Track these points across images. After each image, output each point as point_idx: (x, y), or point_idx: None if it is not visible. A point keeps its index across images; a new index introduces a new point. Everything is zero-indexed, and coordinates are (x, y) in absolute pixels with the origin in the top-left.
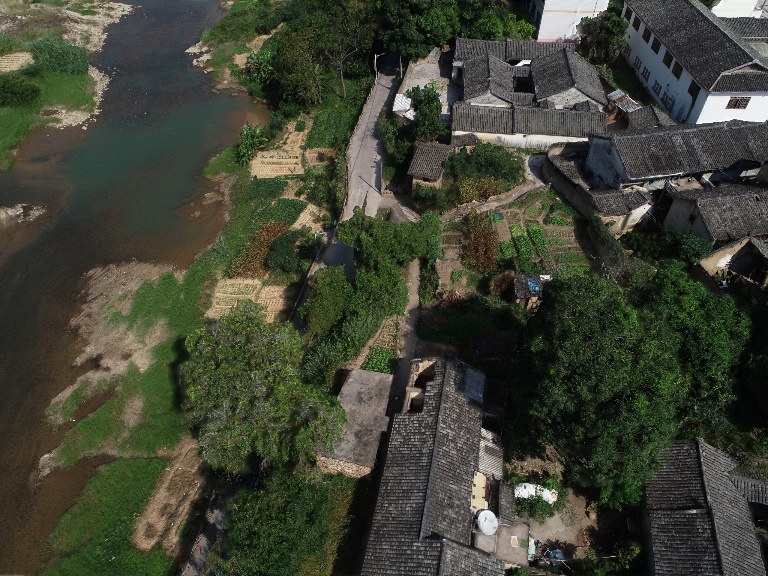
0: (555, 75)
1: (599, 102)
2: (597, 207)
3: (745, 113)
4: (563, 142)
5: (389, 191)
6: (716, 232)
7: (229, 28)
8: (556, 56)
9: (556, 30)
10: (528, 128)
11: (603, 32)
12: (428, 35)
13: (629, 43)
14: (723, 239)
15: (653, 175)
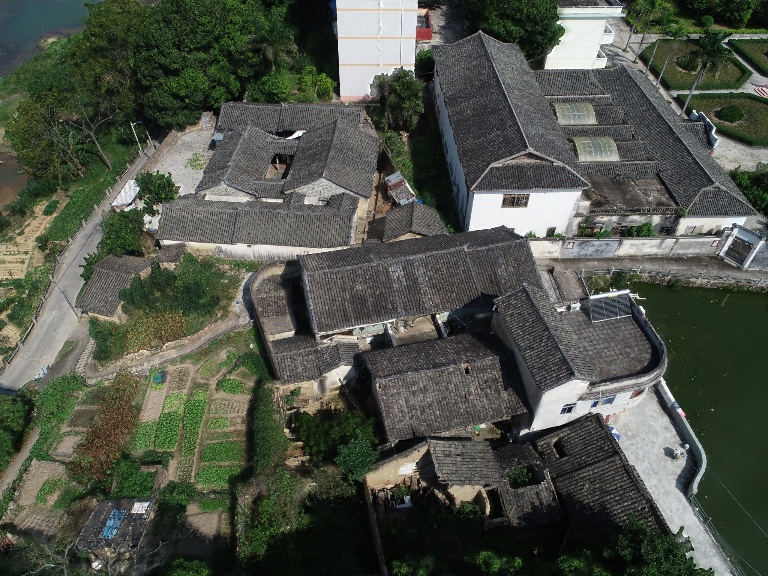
0: (314, 157)
1: (359, 194)
2: (276, 371)
3: (528, 212)
4: (282, 260)
5: (87, 315)
6: (395, 428)
7: (23, 76)
8: (326, 129)
9: (360, 86)
10: (251, 236)
11: (392, 96)
12: (186, 100)
13: (438, 103)
14: (404, 439)
15: (351, 326)
